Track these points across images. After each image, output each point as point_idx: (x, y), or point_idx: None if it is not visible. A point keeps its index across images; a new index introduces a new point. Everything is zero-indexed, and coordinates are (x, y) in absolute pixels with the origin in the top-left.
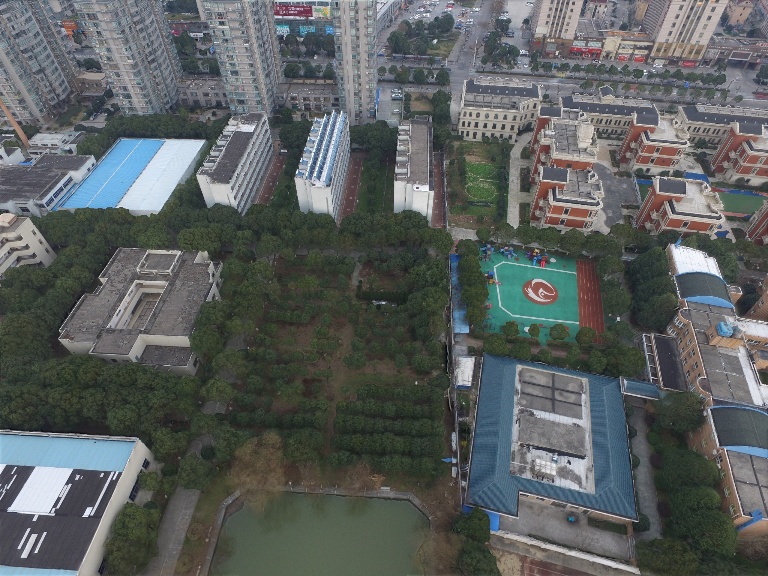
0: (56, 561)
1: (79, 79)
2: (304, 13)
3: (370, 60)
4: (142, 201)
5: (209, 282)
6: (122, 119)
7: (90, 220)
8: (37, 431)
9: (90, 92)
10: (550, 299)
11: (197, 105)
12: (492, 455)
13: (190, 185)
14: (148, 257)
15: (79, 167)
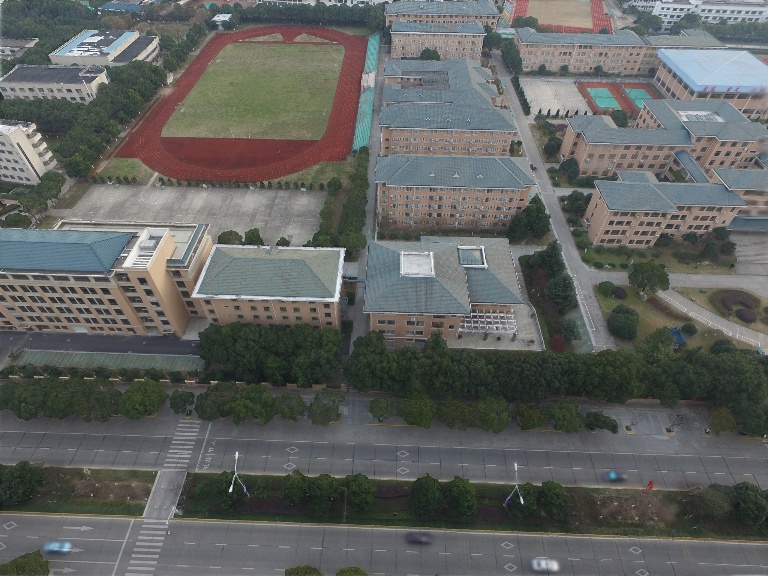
0: (121, 34)
1: None
2: None
3: None
4: None
5: None
6: None
7: None
8: (65, 43)
9: None
10: (83, 4)
11: None
12: (137, 6)
13: None
14: None
15: None
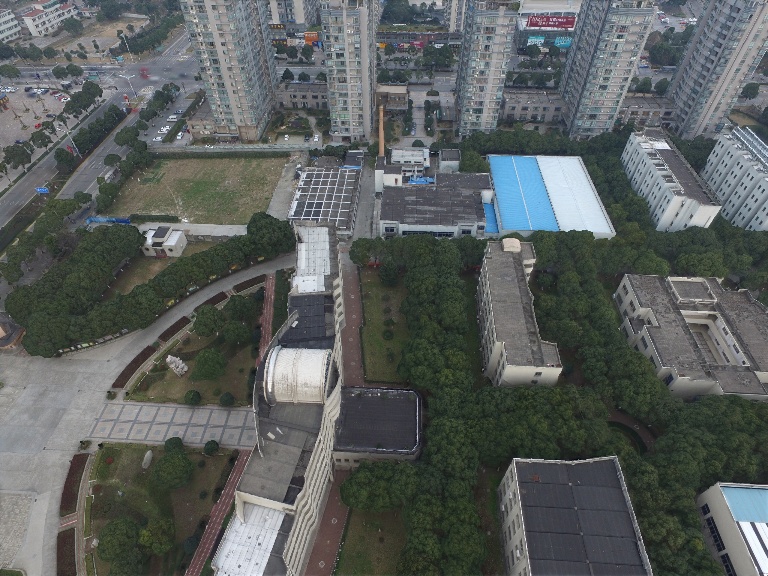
0: None
1: (382, 93)
2: (565, 24)
3: (749, 74)
4: (584, 223)
5: (765, 312)
6: (483, 135)
7: (554, 243)
8: None
9: (392, 106)
10: None
11: (513, 119)
12: None
13: (629, 206)
14: (664, 284)
15: (487, 186)
